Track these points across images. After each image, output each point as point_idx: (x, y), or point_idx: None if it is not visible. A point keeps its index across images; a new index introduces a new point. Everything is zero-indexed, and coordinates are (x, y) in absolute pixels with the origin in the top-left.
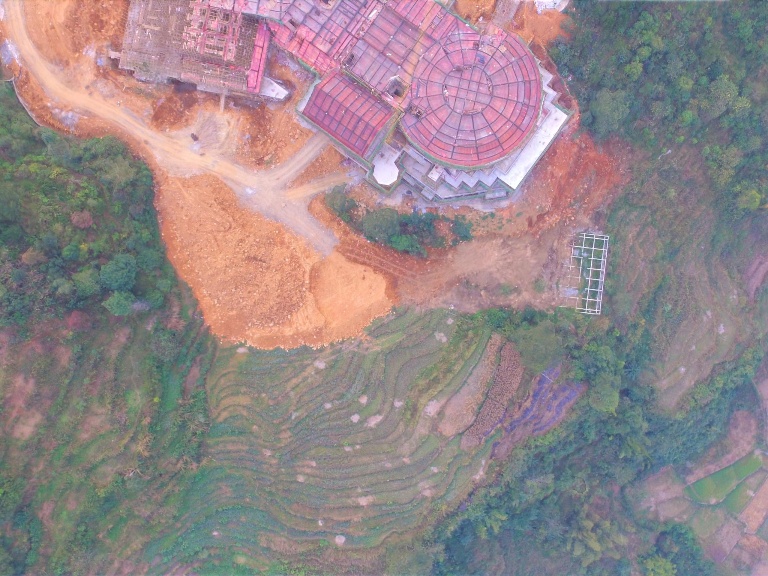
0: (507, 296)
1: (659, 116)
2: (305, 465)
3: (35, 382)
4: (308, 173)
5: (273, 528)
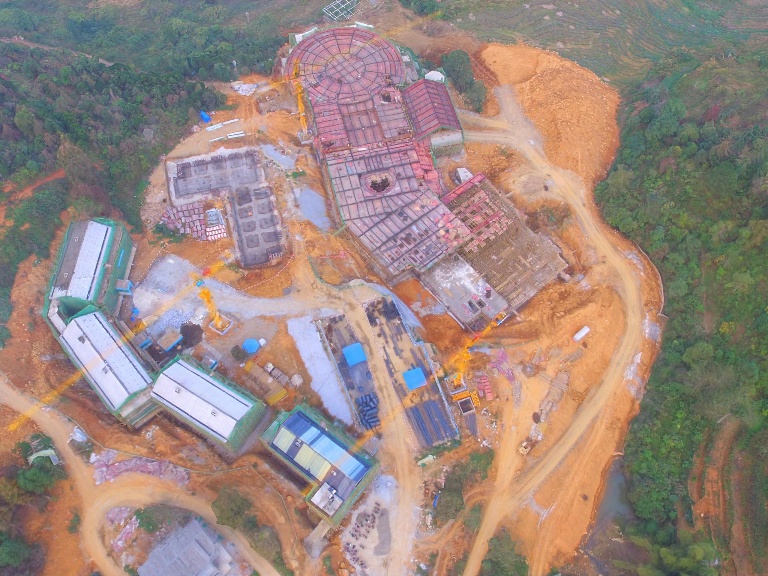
0: (412, 18)
1: (236, 27)
2: (610, 15)
3: (766, 113)
4: None
5: (654, 6)
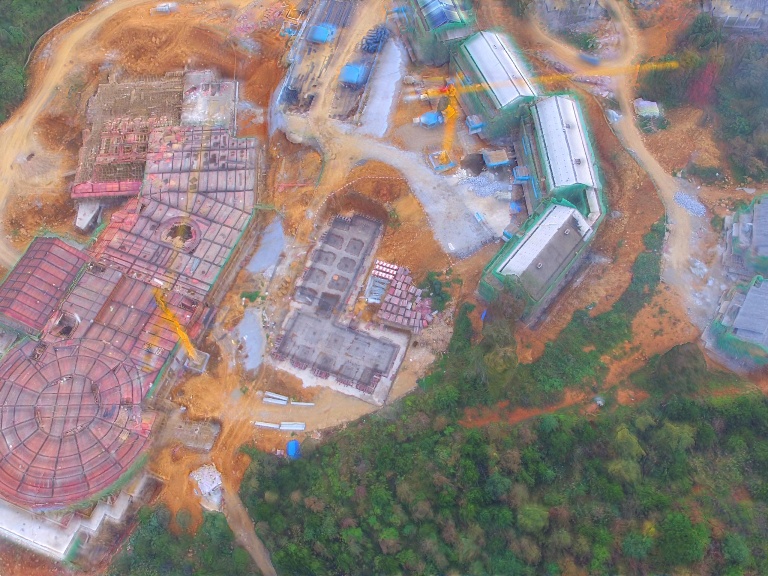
0: None
1: None
2: None
3: None
4: (4, 272)
5: None
